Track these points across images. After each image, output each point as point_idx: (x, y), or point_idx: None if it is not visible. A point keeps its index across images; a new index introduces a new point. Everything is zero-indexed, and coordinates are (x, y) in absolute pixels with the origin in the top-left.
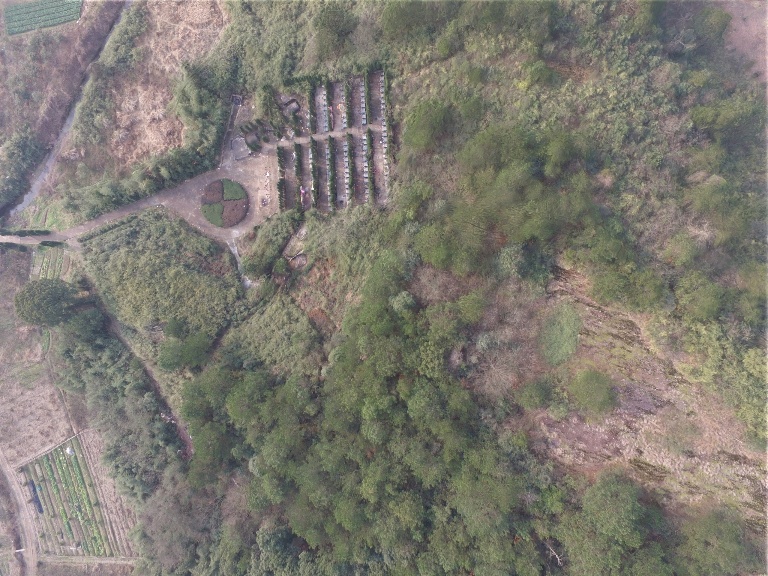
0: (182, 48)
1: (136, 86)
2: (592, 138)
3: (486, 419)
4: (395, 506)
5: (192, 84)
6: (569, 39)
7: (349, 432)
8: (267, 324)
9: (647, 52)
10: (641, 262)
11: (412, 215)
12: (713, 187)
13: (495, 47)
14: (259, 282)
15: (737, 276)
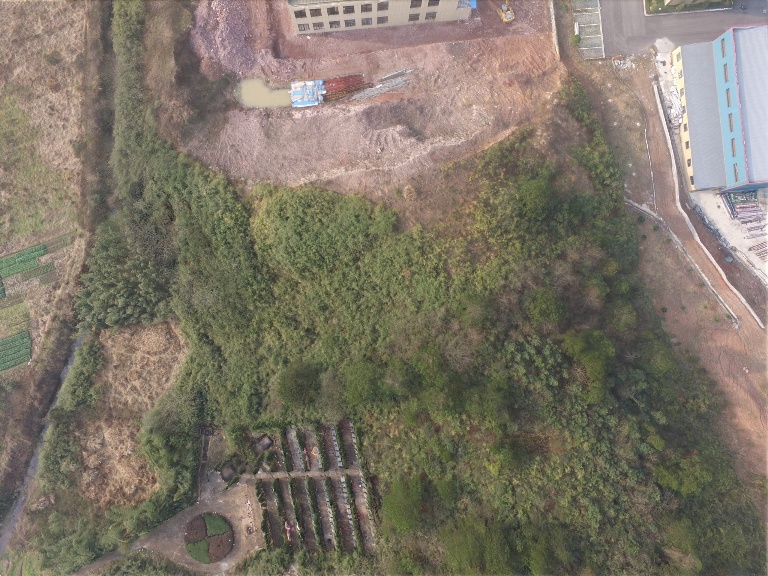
0: (142, 378)
1: (99, 422)
2: (569, 523)
3: None
4: None
5: (159, 437)
6: (530, 413)
7: None
8: None
9: (605, 414)
10: None
11: None
12: (690, 571)
13: (461, 429)
14: None
15: None
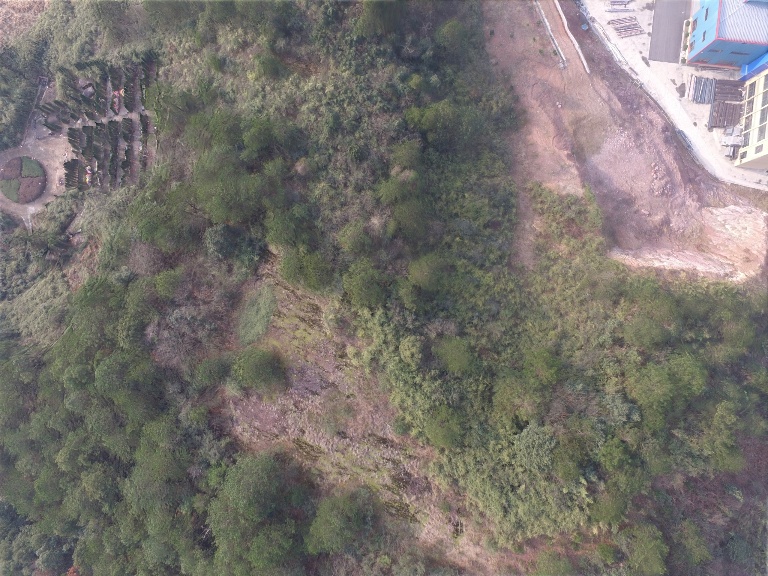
0: (2, 30)
1: None
2: (304, 129)
3: (175, 393)
4: (85, 476)
5: None
6: (302, 37)
7: (55, 401)
8: (33, 297)
9: (374, 54)
10: (319, 247)
11: (149, 195)
12: (401, 181)
13: (233, 40)
14: (37, 257)
15: (412, 266)
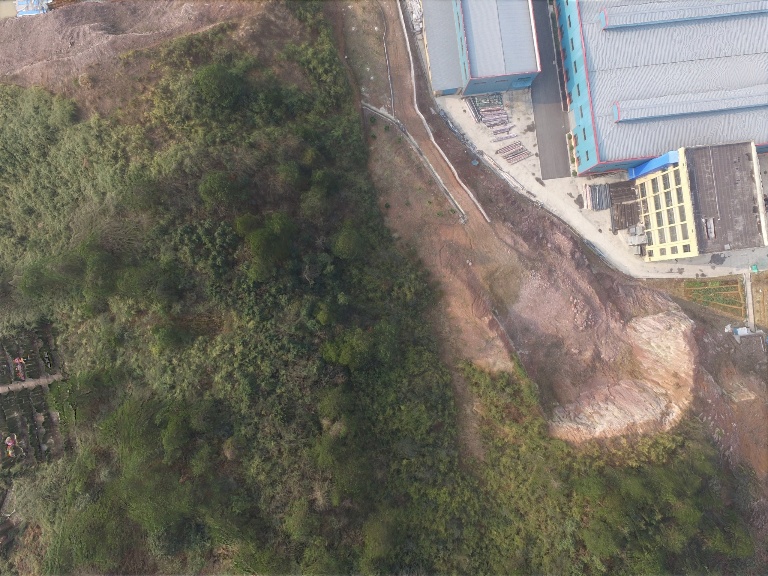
0: None
1: None
2: (223, 399)
3: None
4: None
5: None
6: (197, 294)
7: None
8: None
9: (275, 293)
10: (269, 535)
11: (79, 490)
12: (334, 437)
13: (126, 313)
14: None
15: (366, 526)
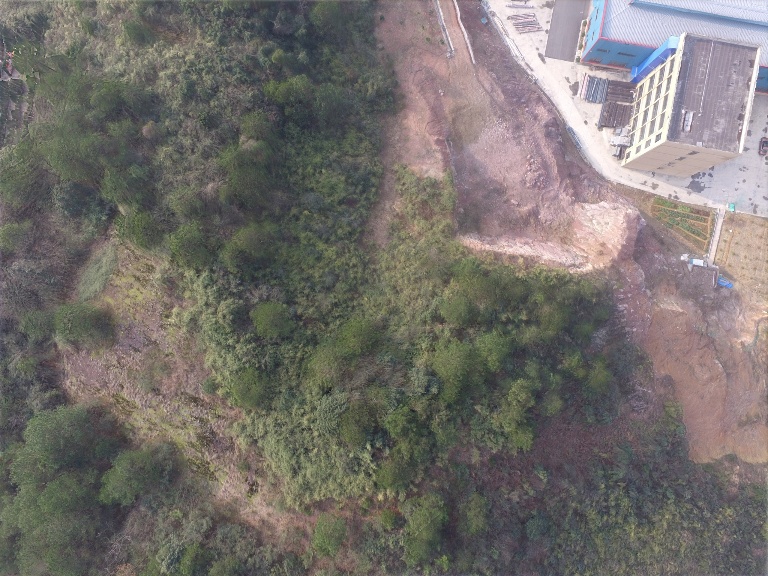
0: None
1: None
2: (161, 95)
3: (10, 344)
4: None
5: None
6: (172, 6)
7: None
8: None
9: (241, 27)
10: (154, 208)
11: (16, 152)
12: (244, 150)
13: (106, 5)
14: None
15: (244, 233)
